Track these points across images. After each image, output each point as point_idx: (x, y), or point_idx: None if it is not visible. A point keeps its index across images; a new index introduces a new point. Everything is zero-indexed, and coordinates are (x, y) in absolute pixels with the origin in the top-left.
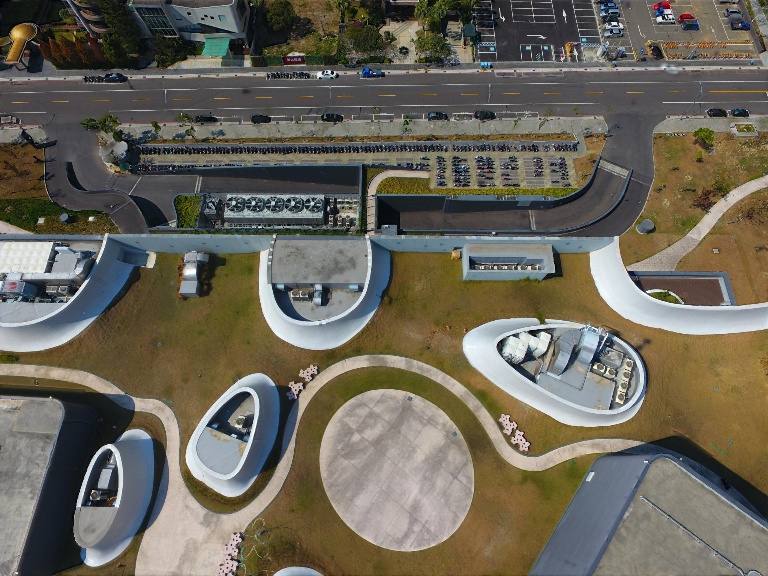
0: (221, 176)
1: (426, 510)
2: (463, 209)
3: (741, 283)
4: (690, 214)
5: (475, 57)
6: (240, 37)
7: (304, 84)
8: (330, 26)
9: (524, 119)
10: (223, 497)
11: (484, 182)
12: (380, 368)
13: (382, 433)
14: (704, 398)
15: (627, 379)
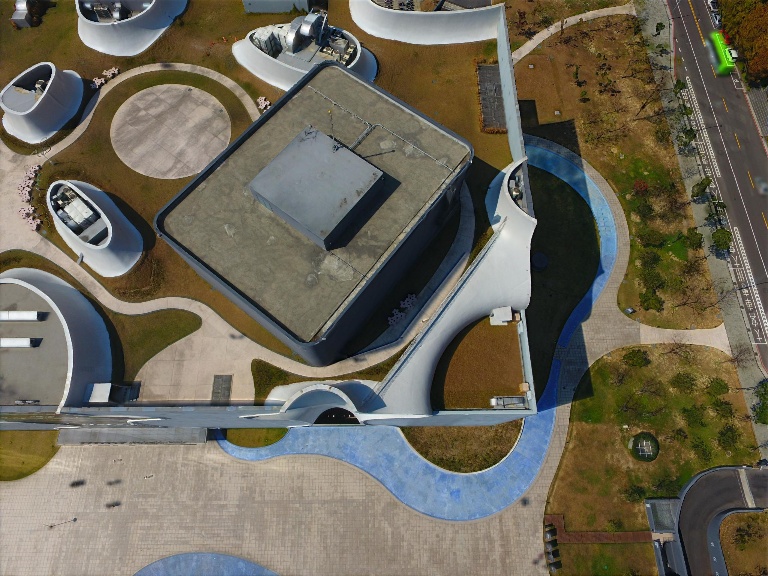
0: None
1: (189, 155)
2: None
3: (549, 90)
4: (515, 40)
5: None
6: None
7: None
8: None
9: None
10: (28, 144)
11: None
12: (170, 71)
13: (164, 110)
14: (423, 87)
15: (347, 56)
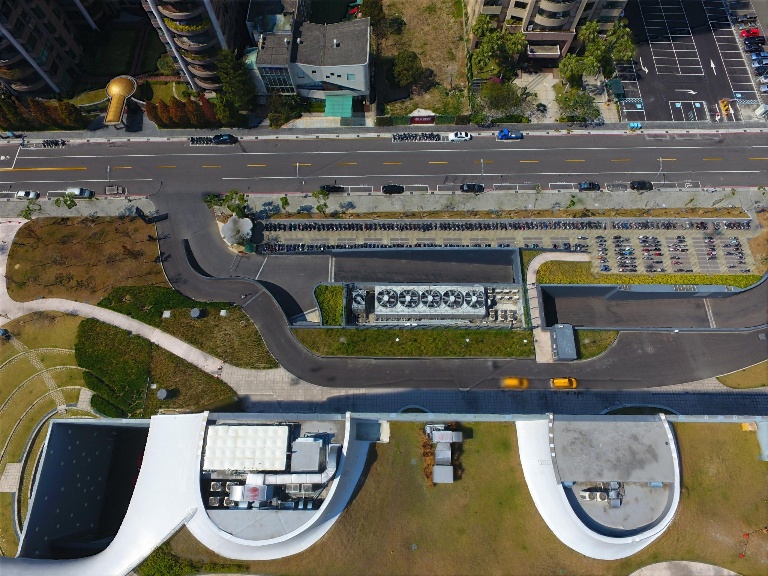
0: (356, 257)
1: None
2: (630, 297)
3: None
4: None
5: (621, 116)
6: (363, 94)
7: (435, 147)
8: (455, 78)
9: (685, 190)
10: None
11: (652, 266)
12: None
13: None
14: None
15: None
